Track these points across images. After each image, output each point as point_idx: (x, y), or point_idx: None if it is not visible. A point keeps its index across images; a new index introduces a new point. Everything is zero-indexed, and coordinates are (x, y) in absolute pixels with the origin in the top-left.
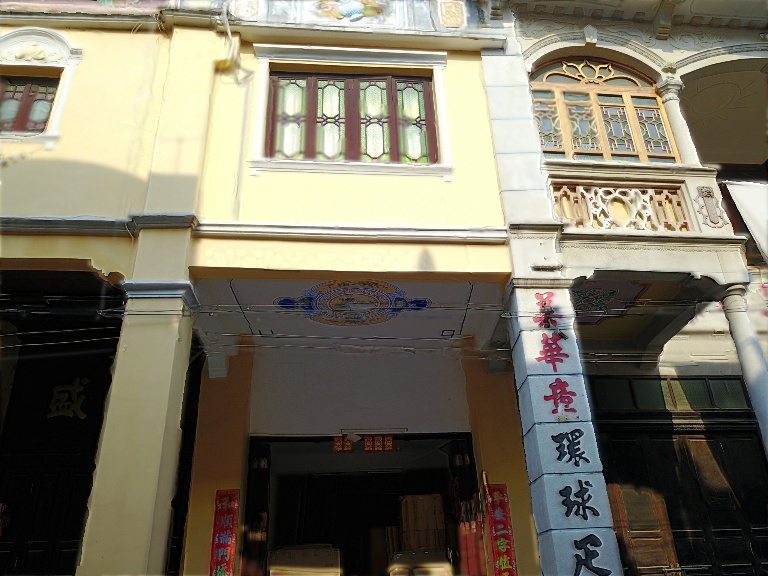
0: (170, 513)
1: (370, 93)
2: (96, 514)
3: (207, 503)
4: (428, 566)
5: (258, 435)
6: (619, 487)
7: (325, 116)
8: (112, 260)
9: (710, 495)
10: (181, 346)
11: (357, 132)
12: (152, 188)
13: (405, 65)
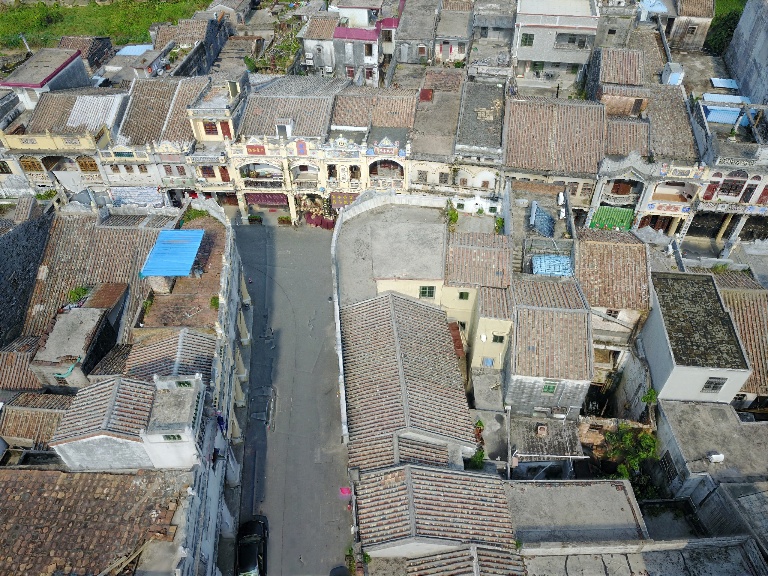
0: None
1: (0, 163)
2: None
3: None
4: None
5: None
6: None
7: None
8: None
9: None
10: None
11: None
12: None
13: None
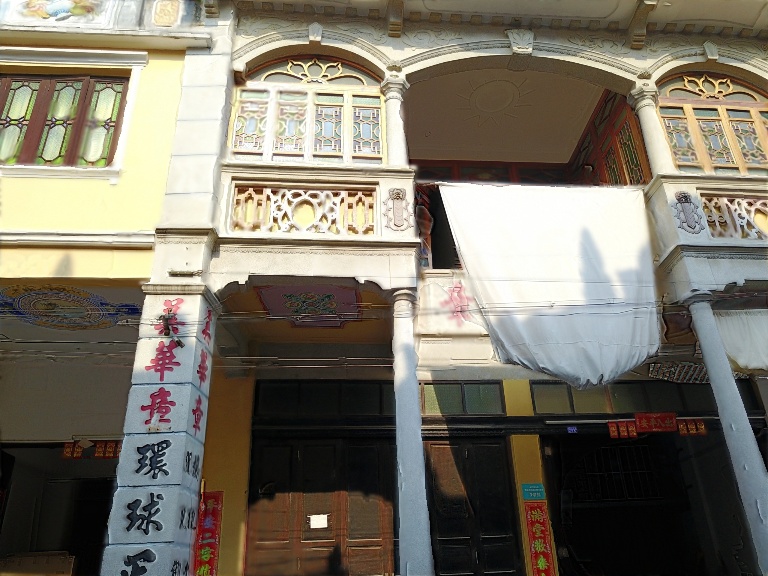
0: None
1: (66, 94)
2: None
3: None
4: None
5: None
6: (347, 494)
7: (9, 118)
8: None
9: (443, 502)
10: None
11: (38, 134)
12: None
13: (103, 65)
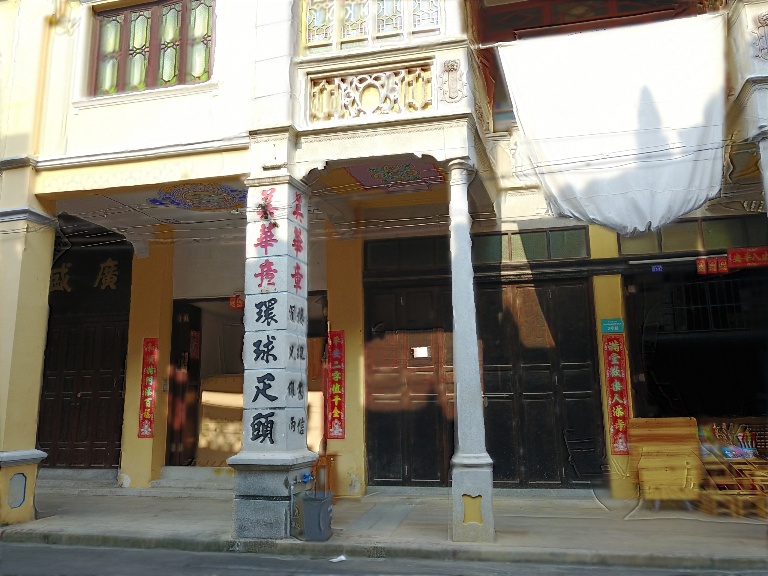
0: (41, 359)
1: (171, 17)
2: None
3: (138, 347)
4: (313, 390)
5: (179, 298)
6: (443, 331)
7: (135, 48)
8: None
9: (527, 336)
10: (26, 253)
11: (157, 58)
12: (8, 138)
13: None
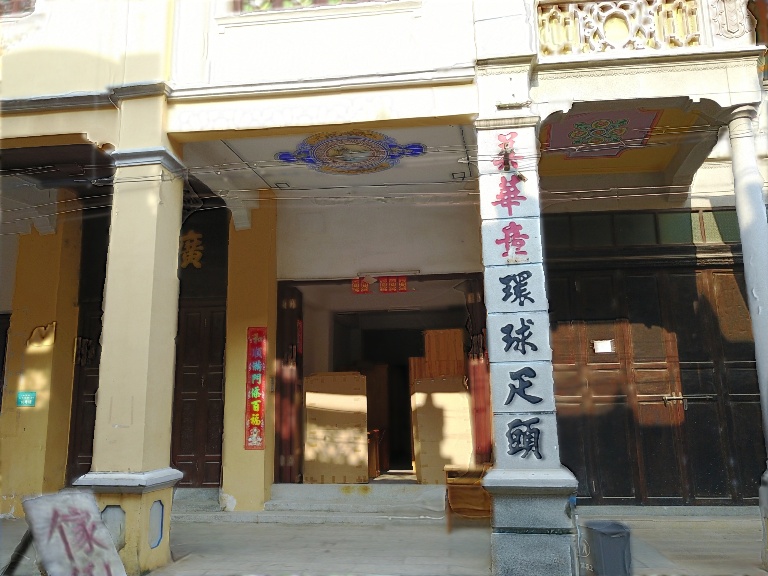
0: (173, 348)
1: None
2: (106, 349)
3: (240, 338)
4: (445, 391)
5: (285, 280)
6: (628, 322)
7: None
8: (104, 132)
9: (728, 329)
10: (163, 208)
11: None
12: (128, 58)
13: None
